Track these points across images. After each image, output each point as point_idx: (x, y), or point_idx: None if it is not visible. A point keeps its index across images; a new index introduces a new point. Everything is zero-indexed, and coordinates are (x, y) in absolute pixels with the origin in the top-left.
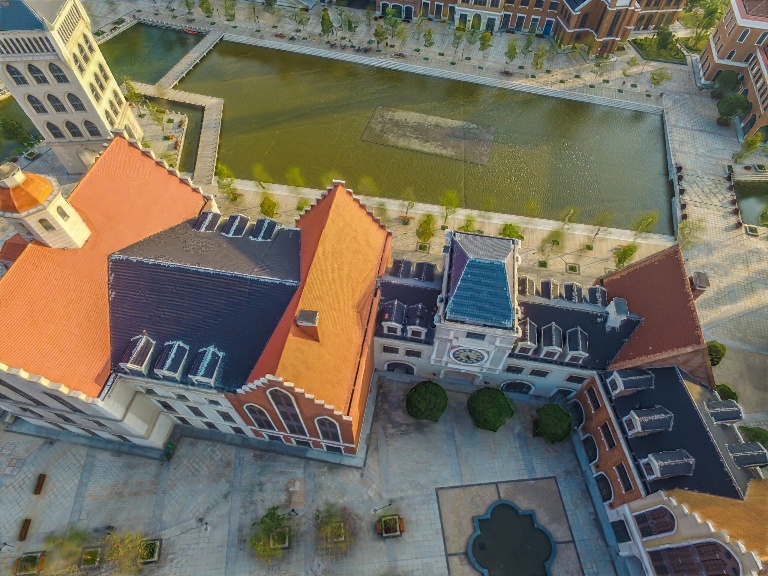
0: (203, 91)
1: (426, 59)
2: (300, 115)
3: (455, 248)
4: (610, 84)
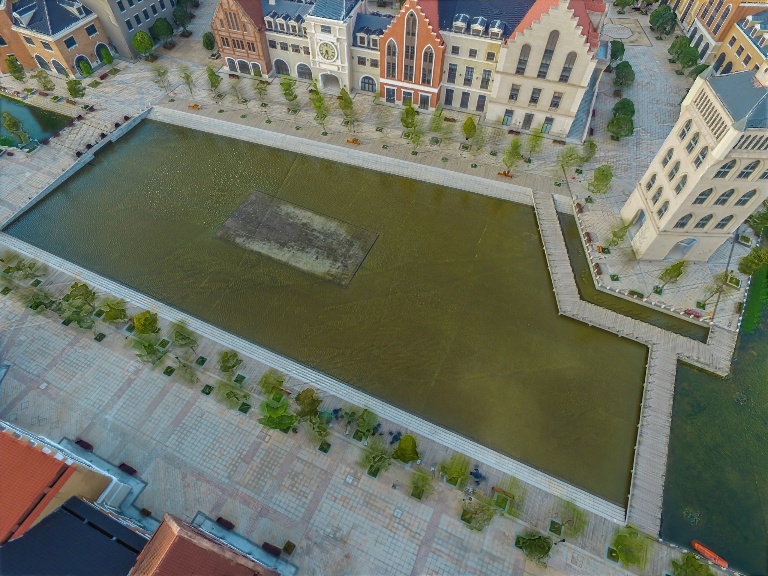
0: (599, 345)
1: (240, 377)
2: (451, 281)
3: (347, 7)
4: (7, 285)
